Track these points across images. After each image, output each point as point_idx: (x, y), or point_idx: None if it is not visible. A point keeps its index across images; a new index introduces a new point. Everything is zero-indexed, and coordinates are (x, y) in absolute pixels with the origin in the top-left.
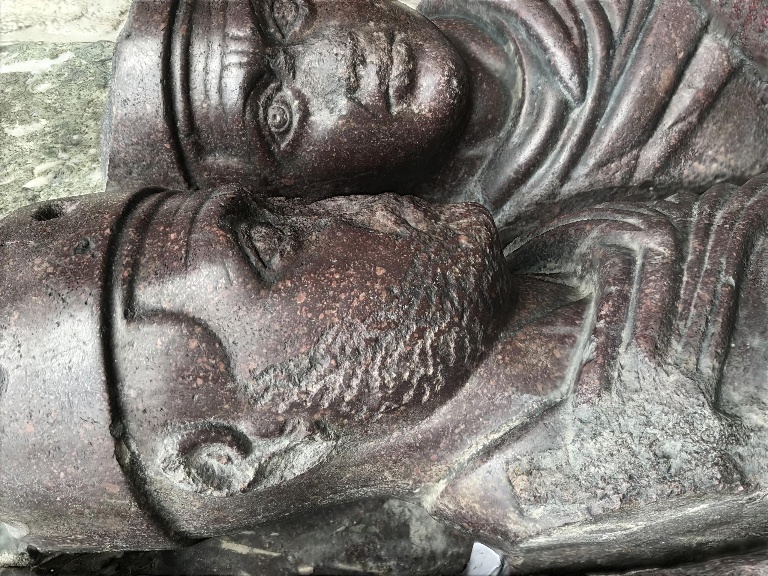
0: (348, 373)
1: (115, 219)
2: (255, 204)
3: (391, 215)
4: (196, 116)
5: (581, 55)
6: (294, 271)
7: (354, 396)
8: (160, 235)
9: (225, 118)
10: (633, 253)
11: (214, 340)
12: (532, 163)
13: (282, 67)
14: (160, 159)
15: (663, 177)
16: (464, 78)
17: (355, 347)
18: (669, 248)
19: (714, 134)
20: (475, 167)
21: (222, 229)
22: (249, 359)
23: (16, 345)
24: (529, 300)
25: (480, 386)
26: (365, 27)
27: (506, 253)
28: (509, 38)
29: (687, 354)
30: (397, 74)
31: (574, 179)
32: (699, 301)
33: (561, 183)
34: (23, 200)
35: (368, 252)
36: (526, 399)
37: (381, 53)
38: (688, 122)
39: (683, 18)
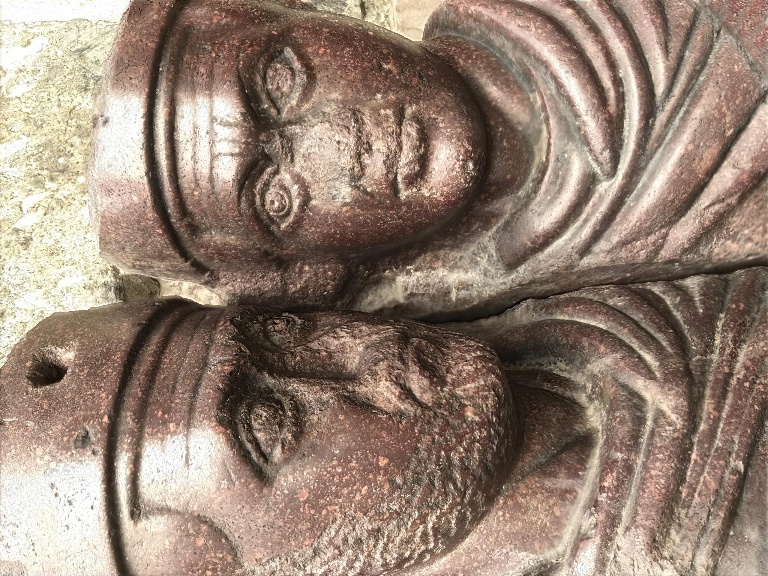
0: (351, 559)
1: (112, 401)
2: (254, 369)
3: (395, 387)
4: (187, 202)
5: (616, 125)
6: (296, 464)
7: (357, 573)
8: (159, 423)
9: (219, 206)
10: (645, 406)
11: (220, 536)
12: (551, 235)
13: (278, 151)
14: (153, 240)
15: (691, 255)
16: (482, 154)
17: (358, 538)
18: (682, 417)
19: (754, 213)
20: (490, 223)
21: (221, 424)
22: (255, 551)
23: (30, 544)
24: (534, 439)
25: (479, 542)
26: (371, 102)
27: (517, 313)
28: (536, 89)
29: (684, 549)
30: (406, 162)
31: (595, 253)
32: (704, 489)
33: (581, 256)
34: (15, 244)
35: (371, 440)
36: (523, 557)
37: (389, 139)
38: (727, 204)
39: (739, 87)
